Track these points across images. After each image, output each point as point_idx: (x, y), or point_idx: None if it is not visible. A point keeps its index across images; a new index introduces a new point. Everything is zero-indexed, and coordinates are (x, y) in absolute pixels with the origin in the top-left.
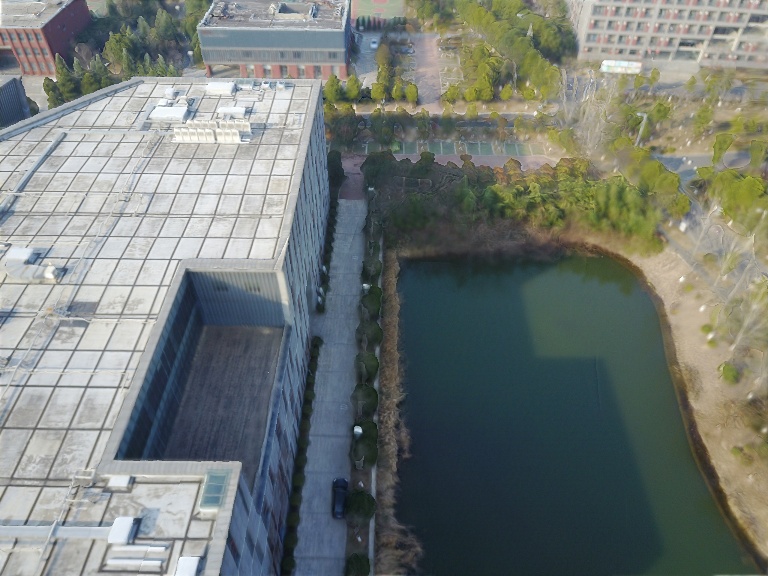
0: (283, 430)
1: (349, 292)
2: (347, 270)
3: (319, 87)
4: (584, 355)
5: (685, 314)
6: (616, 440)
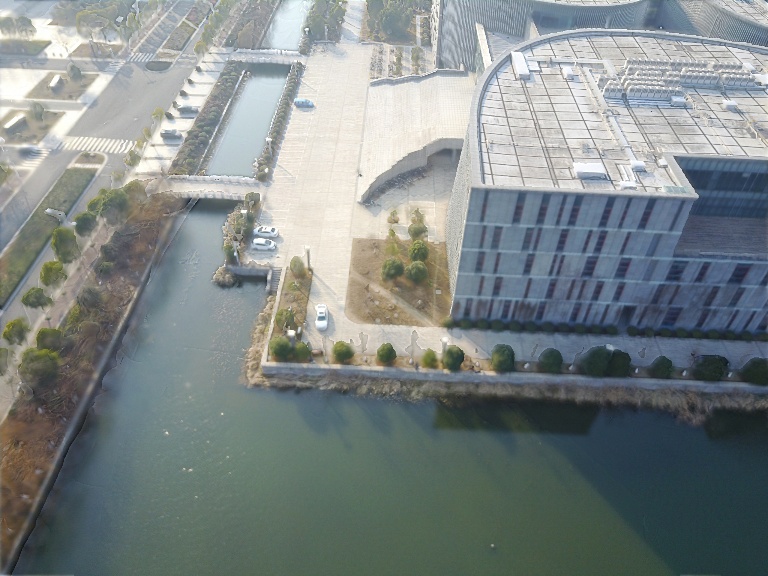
0: (743, 283)
1: None
2: None
3: None
4: None
5: None
6: None
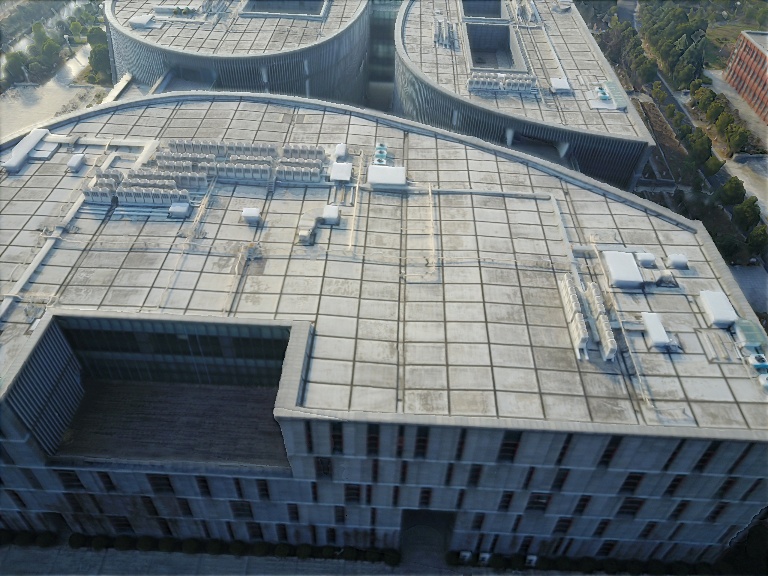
0: (177, 494)
1: None
2: None
3: None
4: None
5: None
6: None
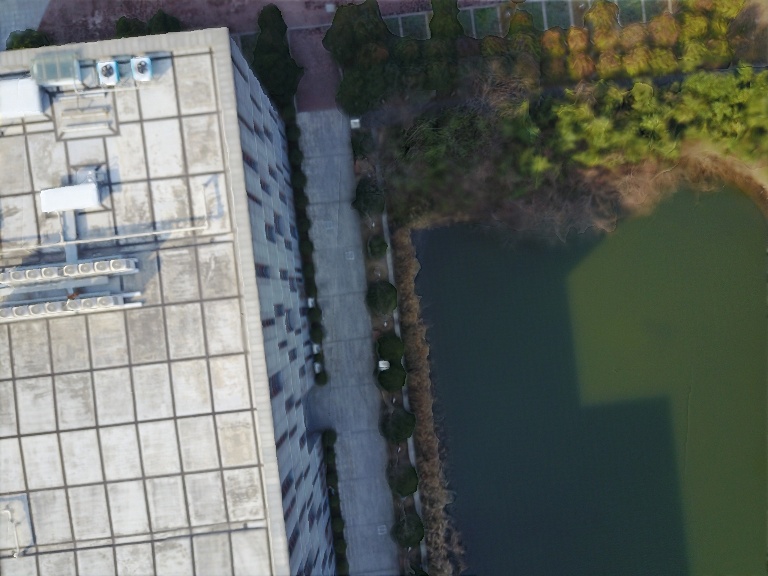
0: None
1: (354, 332)
2: (343, 287)
3: (230, 68)
4: (676, 391)
5: None
6: (699, 512)
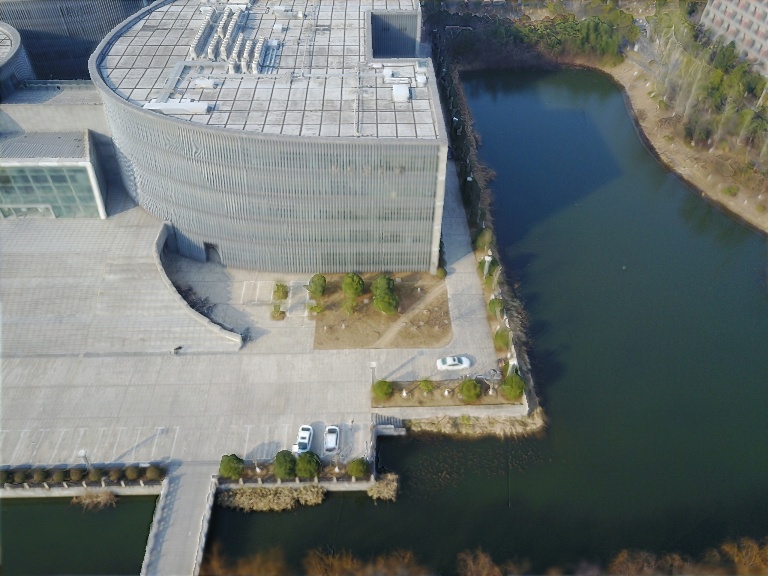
0: None
1: None
2: None
3: None
4: (577, 108)
5: (637, 89)
6: (598, 139)
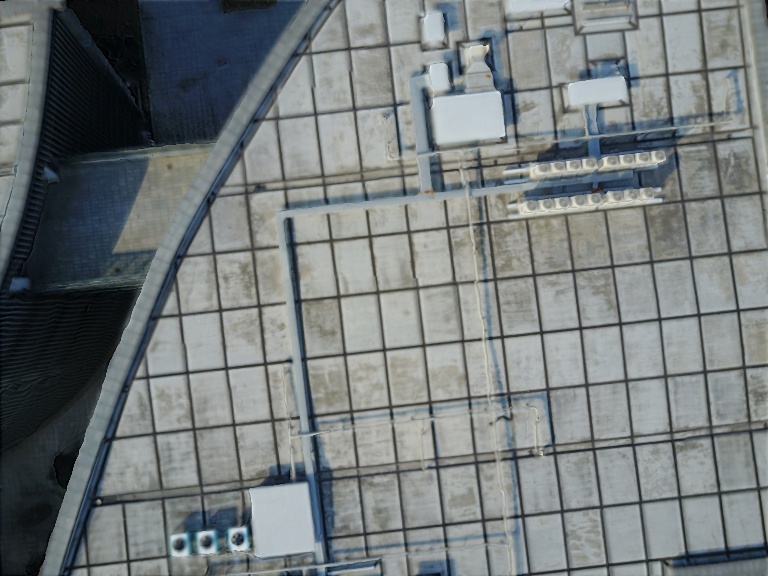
0: None
1: None
2: None
3: None
4: None
5: None
6: None
